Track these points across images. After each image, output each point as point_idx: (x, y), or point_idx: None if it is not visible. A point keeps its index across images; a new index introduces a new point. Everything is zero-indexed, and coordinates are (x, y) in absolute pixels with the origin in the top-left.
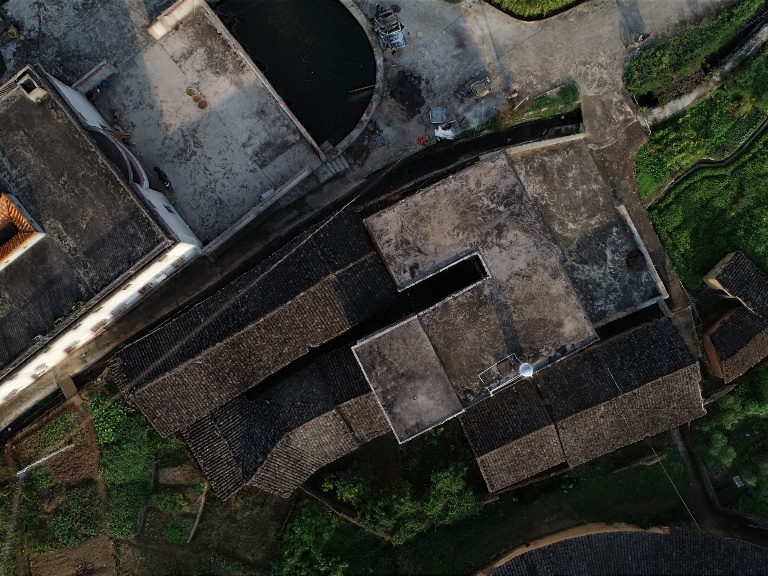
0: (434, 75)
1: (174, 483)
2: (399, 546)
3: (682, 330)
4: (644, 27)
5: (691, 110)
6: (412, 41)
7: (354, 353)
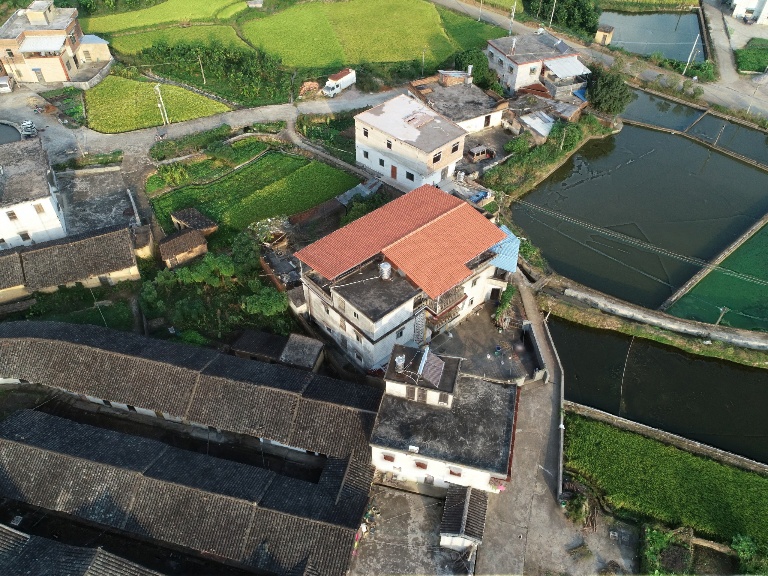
0: (49, 148)
1: None
2: None
3: (140, 234)
4: (168, 136)
5: (190, 166)
6: (44, 139)
7: None
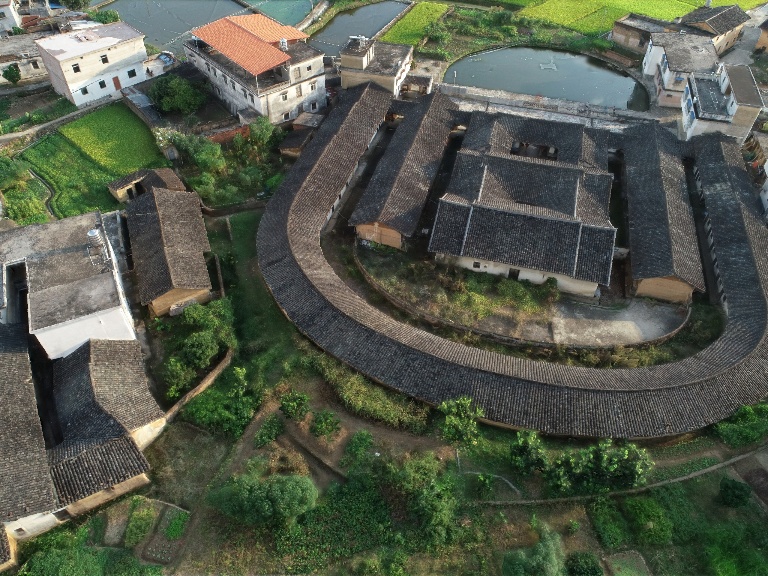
0: None
1: (124, 527)
2: (246, 350)
3: None
4: None
5: None
6: None
7: (35, 331)
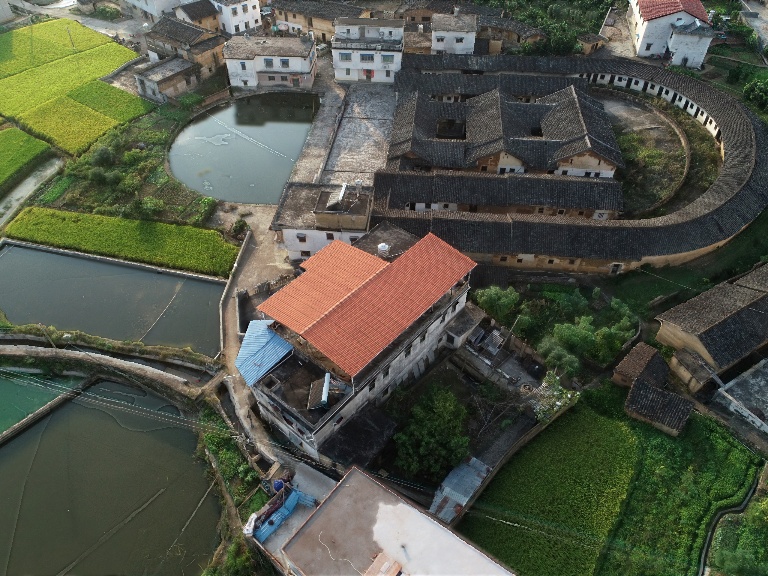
0: None
1: None
2: None
3: (698, 368)
4: None
5: None
6: None
7: None
